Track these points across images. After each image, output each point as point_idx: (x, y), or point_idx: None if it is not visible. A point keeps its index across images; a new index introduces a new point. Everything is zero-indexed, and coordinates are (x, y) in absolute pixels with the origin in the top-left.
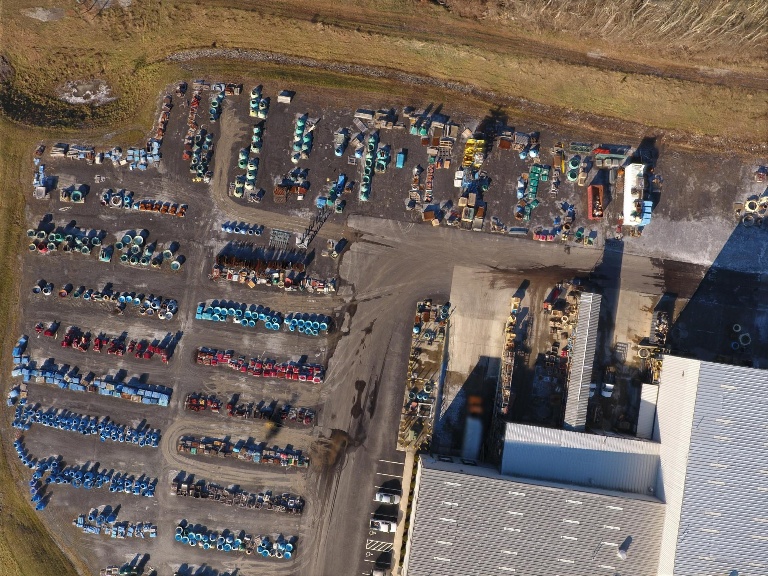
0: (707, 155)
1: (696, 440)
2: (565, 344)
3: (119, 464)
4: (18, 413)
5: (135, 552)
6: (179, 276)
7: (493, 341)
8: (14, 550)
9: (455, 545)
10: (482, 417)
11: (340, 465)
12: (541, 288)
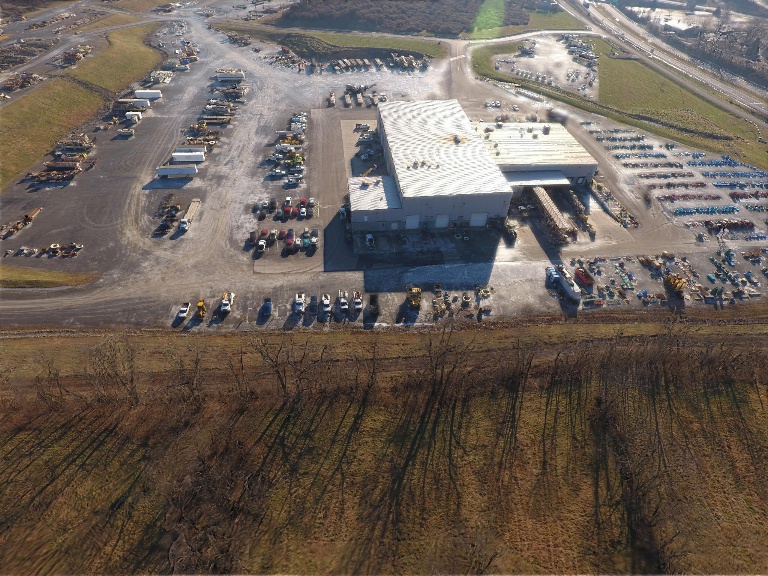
0: (529, 315)
1: (498, 171)
2: None
3: None
4: None
5: None
6: (761, 219)
7: (590, 220)
8: None
9: None
10: None
11: None
12: (583, 240)
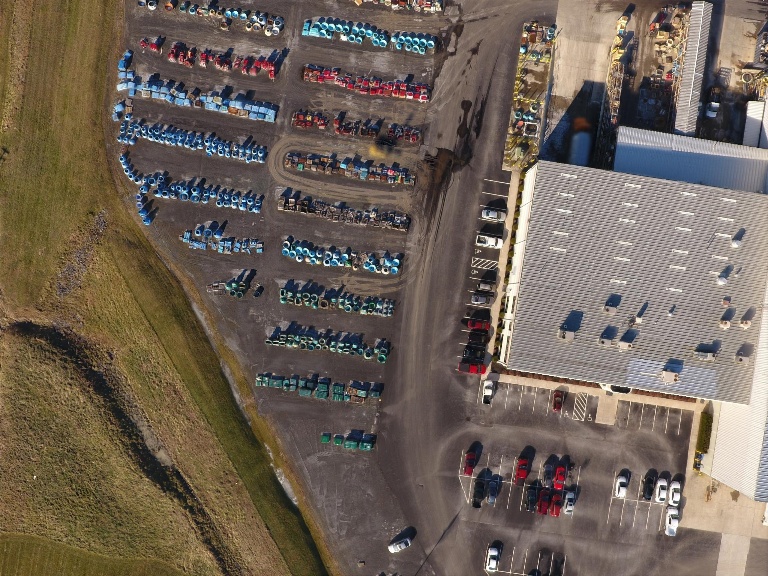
0: None
1: None
2: (670, 68)
3: (225, 180)
4: (124, 127)
5: (241, 268)
6: None
7: (598, 65)
8: (120, 265)
9: (571, 235)
10: (586, 141)
11: (446, 184)
12: (646, 12)
